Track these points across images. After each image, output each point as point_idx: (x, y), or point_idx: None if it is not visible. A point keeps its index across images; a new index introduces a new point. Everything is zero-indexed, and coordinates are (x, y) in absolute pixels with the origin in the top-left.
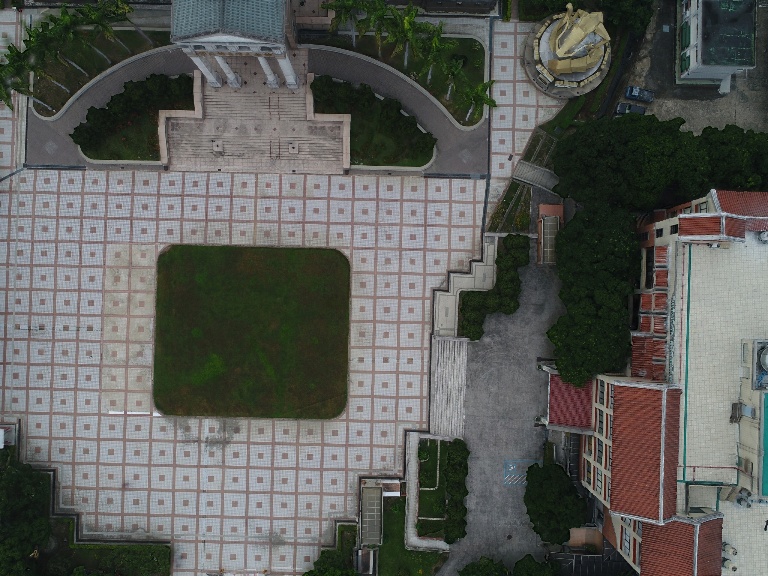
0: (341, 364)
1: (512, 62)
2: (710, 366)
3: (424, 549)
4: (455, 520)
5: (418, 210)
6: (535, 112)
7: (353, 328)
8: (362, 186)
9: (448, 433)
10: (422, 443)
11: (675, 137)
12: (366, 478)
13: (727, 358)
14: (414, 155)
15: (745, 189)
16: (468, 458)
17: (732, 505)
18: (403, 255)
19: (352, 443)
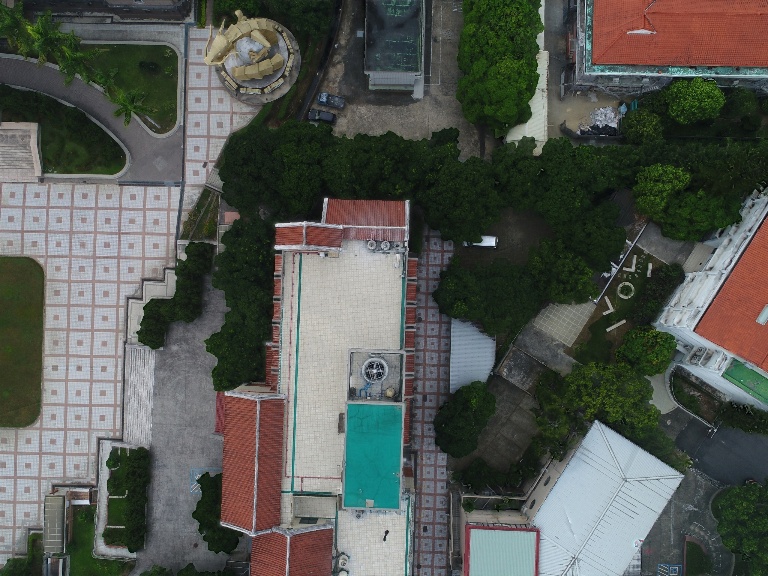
0: (35, 372)
1: (207, 69)
2: (319, 376)
3: (111, 557)
4: (129, 529)
5: (112, 218)
6: (230, 119)
7: (47, 336)
8: (57, 194)
9: (138, 441)
10: (113, 451)
11: (327, 144)
12: (59, 486)
13: (336, 368)
14: (106, 163)
15: (398, 196)
16: (155, 466)
17: (351, 515)
18: (97, 263)
19: (45, 451)
